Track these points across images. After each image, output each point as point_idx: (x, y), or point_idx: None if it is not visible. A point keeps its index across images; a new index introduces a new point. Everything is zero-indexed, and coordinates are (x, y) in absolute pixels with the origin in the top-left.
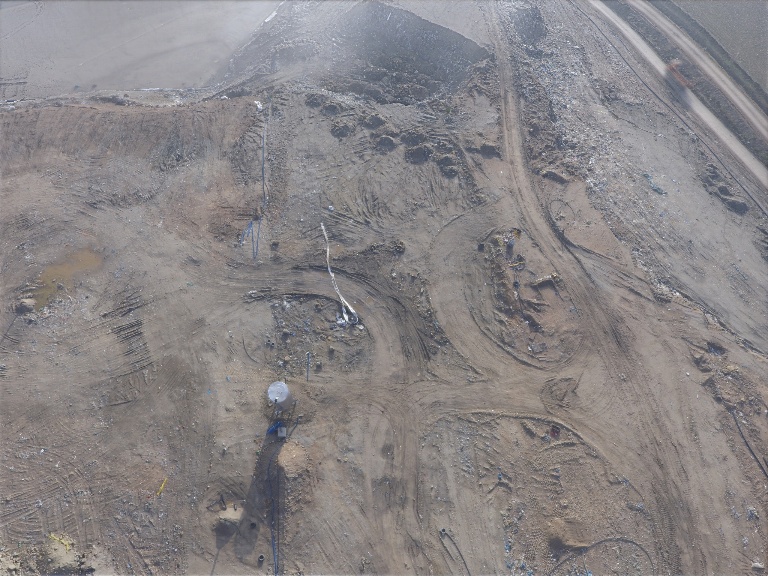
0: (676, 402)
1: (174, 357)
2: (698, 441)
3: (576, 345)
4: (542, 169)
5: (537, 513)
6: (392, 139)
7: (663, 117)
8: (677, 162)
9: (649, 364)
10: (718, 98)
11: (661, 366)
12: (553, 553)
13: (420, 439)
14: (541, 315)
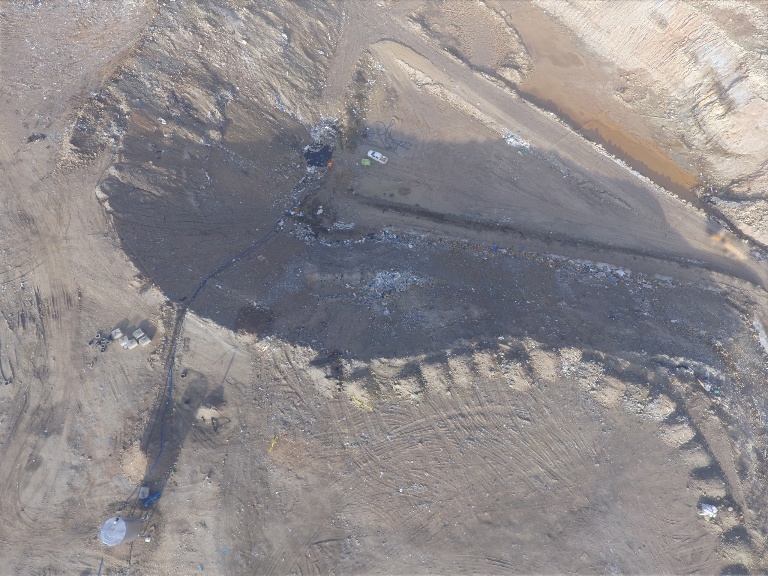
0: None
1: None
2: None
3: None
4: None
5: None
6: None
7: None
8: None
9: None
10: None
11: None
12: None
13: None
14: None
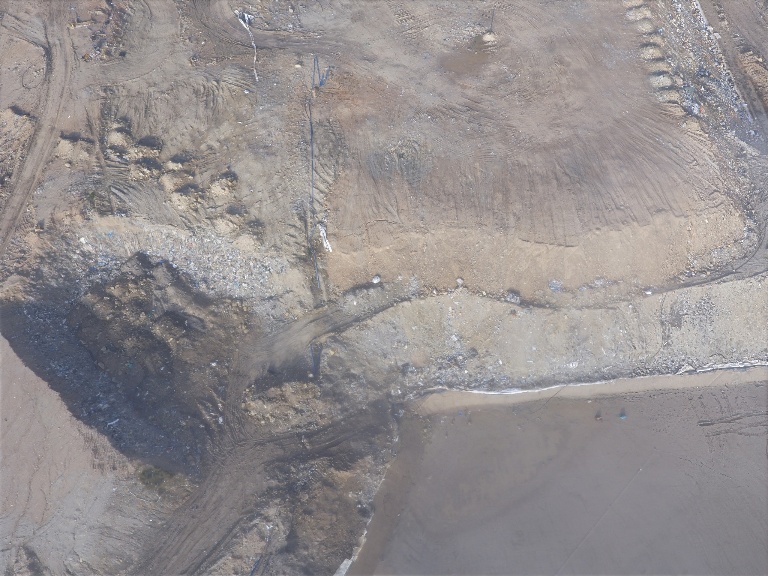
0: None
1: (369, 2)
2: None
3: None
4: None
5: None
6: (171, 163)
7: None
8: None
9: None
10: None
11: None
12: None
13: None
14: (99, 6)
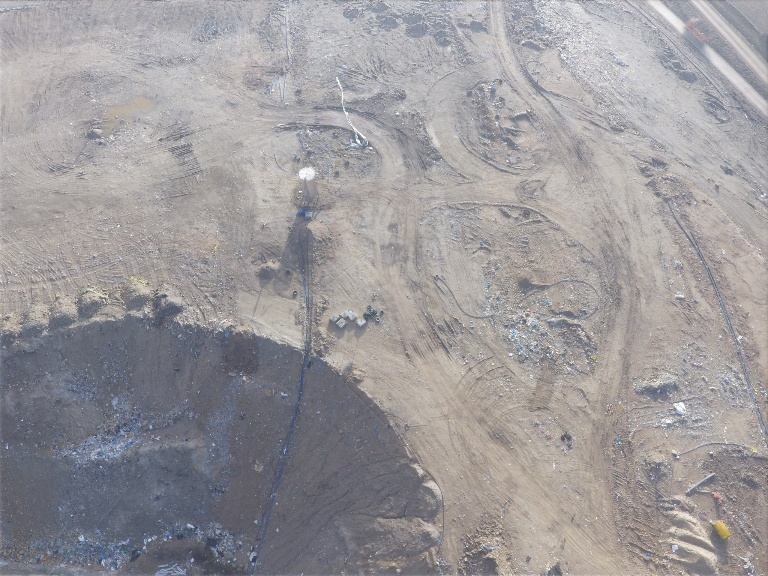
0: (624, 196)
1: (219, 167)
2: (639, 220)
3: (545, 159)
4: (522, 40)
5: (510, 265)
6: (395, 19)
7: (630, 15)
8: (639, 45)
9: (603, 171)
10: (679, 1)
11: (613, 173)
12: (522, 290)
13: (419, 220)
14: (517, 138)
